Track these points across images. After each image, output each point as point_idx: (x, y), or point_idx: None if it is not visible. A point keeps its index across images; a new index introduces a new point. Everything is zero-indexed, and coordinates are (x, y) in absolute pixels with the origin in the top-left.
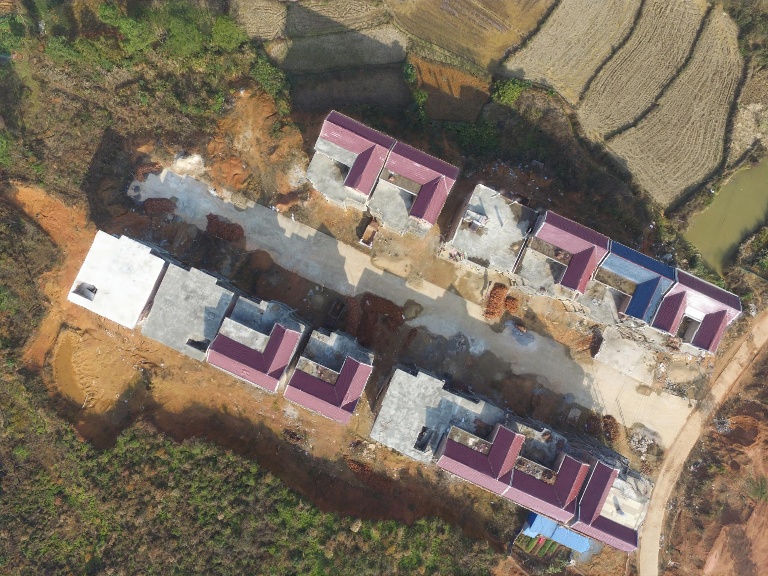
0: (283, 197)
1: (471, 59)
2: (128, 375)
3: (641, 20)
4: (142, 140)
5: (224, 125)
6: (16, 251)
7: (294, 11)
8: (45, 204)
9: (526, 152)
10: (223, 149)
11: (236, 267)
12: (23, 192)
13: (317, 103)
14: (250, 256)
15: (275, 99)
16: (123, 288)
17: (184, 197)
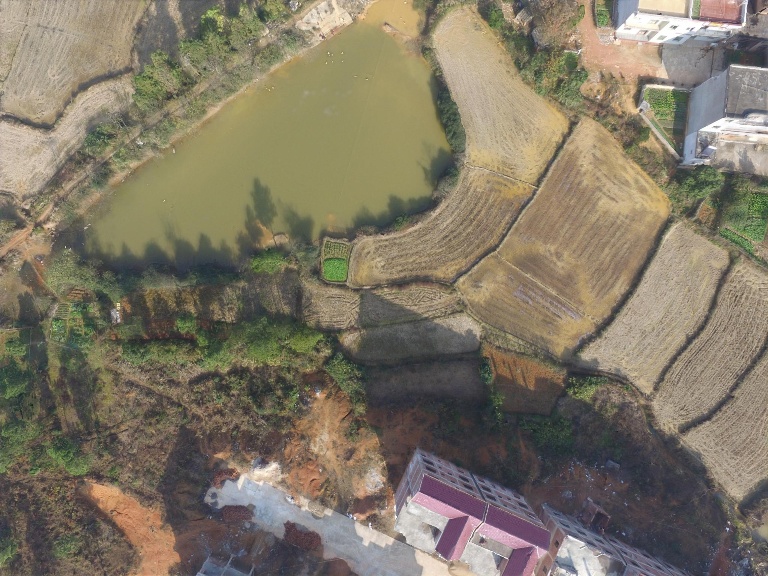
0: (360, 503)
1: (545, 348)
2: None
3: (716, 309)
4: (218, 444)
5: (300, 426)
6: (92, 551)
7: (367, 299)
8: (119, 501)
9: (602, 453)
10: (299, 451)
11: None
12: (97, 487)
13: (391, 396)
14: (328, 565)
15: (350, 397)
16: None
17: (261, 504)
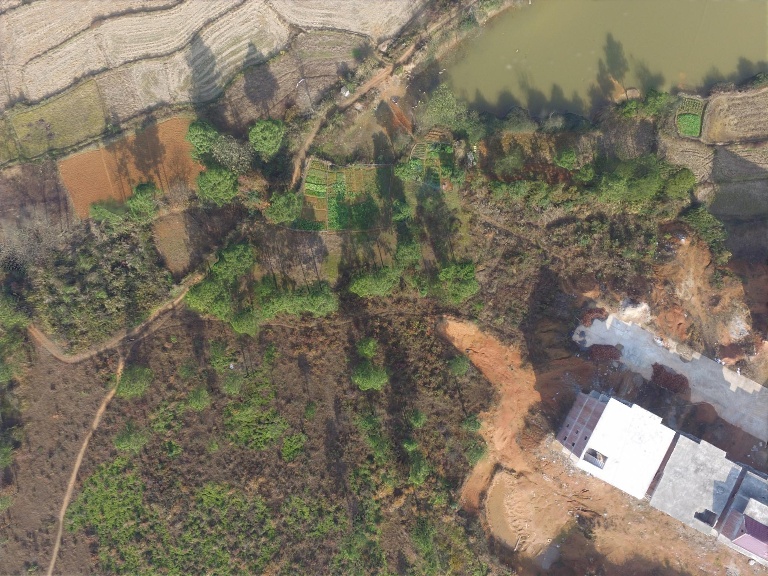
0: (725, 349)
1: None
2: (562, 520)
3: None
4: (586, 284)
5: (663, 271)
6: (450, 387)
7: (721, 155)
8: (475, 339)
9: None
10: (663, 296)
11: (681, 419)
12: (452, 326)
13: (746, 251)
14: (695, 408)
15: (711, 247)
16: (634, 458)
17: (629, 345)
